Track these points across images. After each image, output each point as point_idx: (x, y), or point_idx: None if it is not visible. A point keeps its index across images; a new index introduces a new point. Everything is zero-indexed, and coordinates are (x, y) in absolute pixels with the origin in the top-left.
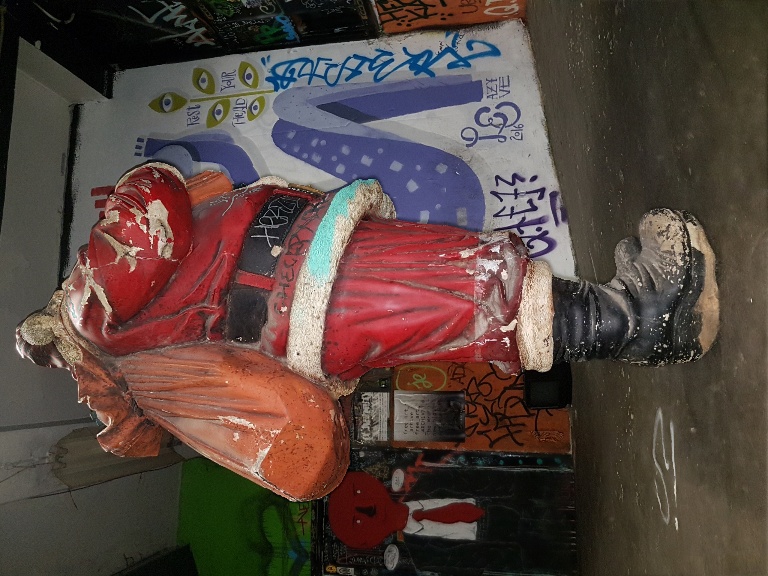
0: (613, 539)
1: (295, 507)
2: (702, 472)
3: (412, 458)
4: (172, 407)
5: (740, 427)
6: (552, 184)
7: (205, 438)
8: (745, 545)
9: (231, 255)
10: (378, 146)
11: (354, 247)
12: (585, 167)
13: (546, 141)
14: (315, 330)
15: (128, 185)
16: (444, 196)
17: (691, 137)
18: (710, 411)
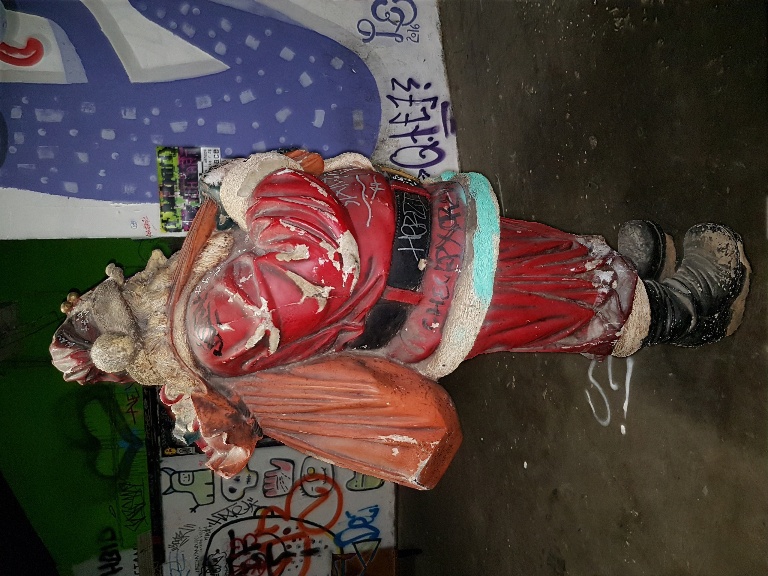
0: (485, 411)
1: (122, 398)
2: (678, 406)
3: None
4: (314, 428)
5: (753, 394)
6: (444, 94)
7: (352, 453)
8: (738, 468)
9: (387, 274)
10: (265, 26)
11: None
12: (518, 104)
13: (440, 47)
14: (471, 346)
15: (293, 204)
16: (340, 95)
17: (742, 166)
18: (703, 370)
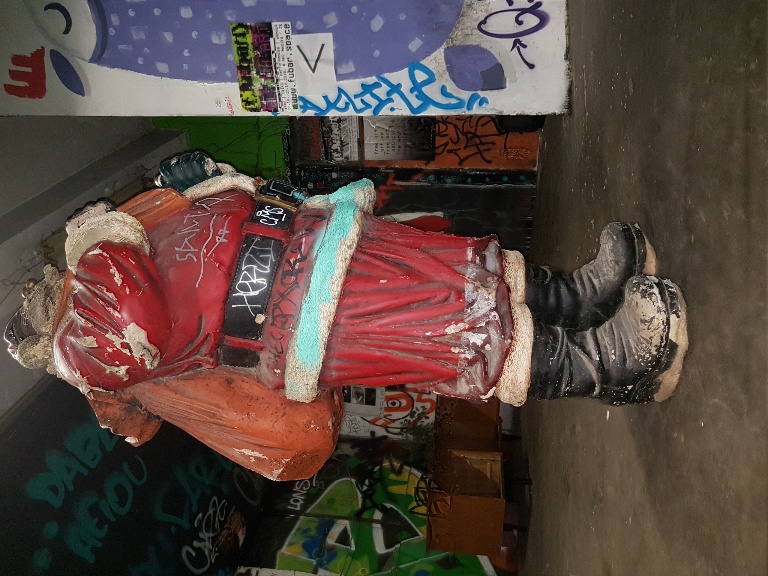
0: None
1: None
2: (633, 430)
3: (383, 178)
4: (189, 428)
5: (666, 469)
6: None
7: None
8: (647, 523)
9: (216, 332)
10: None
11: (340, 318)
12: None
13: None
14: (310, 394)
15: None
16: None
17: (703, 220)
18: (650, 412)
